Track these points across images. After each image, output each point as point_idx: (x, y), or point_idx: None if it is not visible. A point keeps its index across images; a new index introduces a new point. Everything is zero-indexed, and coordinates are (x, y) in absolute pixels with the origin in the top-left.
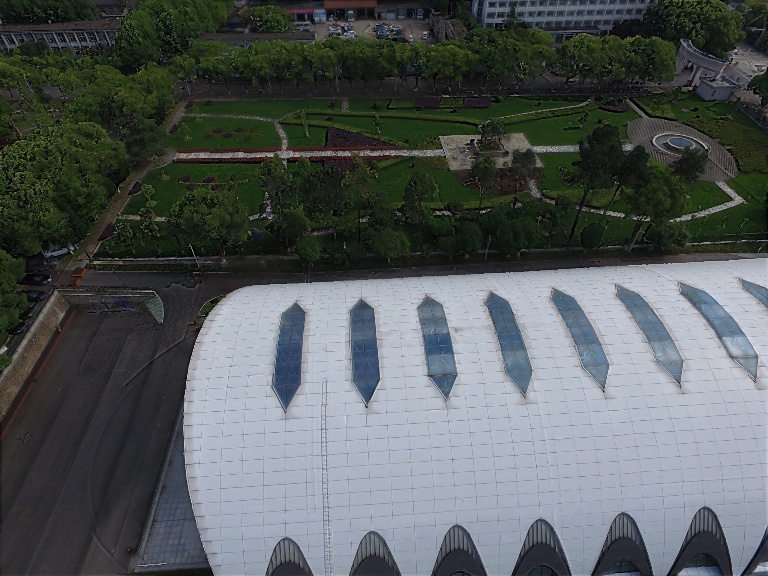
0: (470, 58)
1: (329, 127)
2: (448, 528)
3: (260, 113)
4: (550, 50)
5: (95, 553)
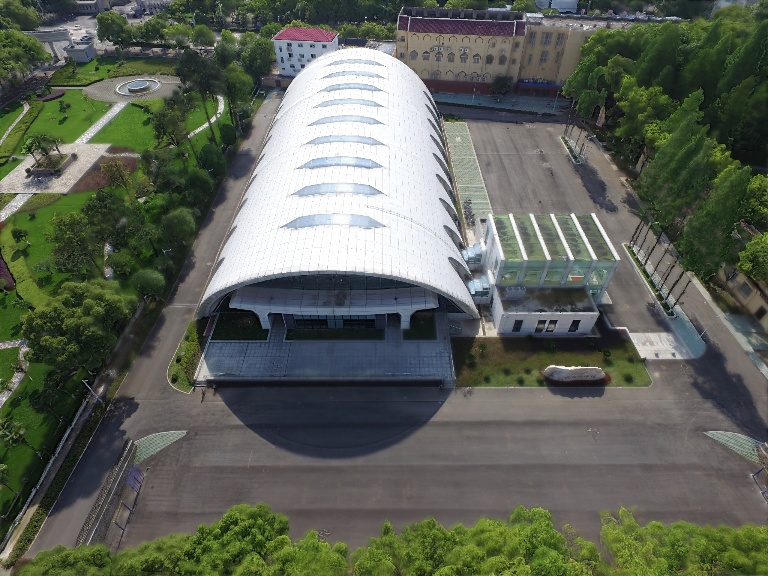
0: None
1: None
2: (440, 202)
3: None
4: None
5: (442, 415)
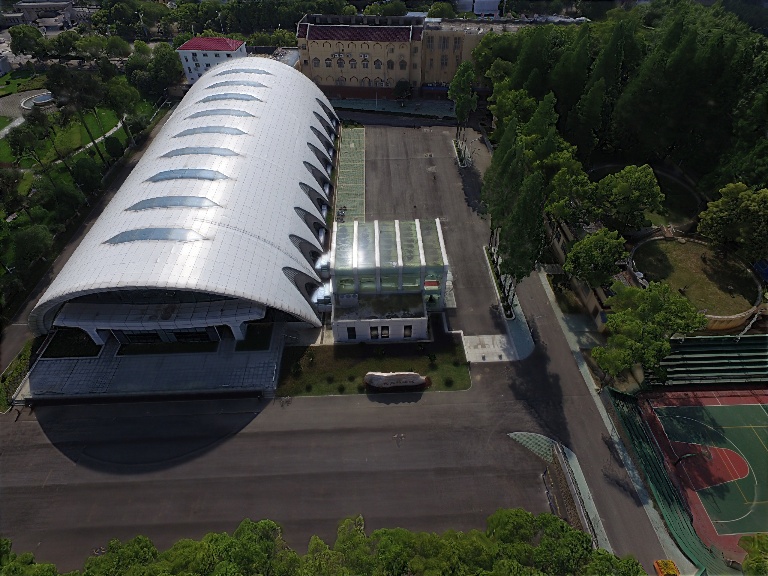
0: None
1: None
2: (295, 211)
3: None
4: None
5: (254, 426)
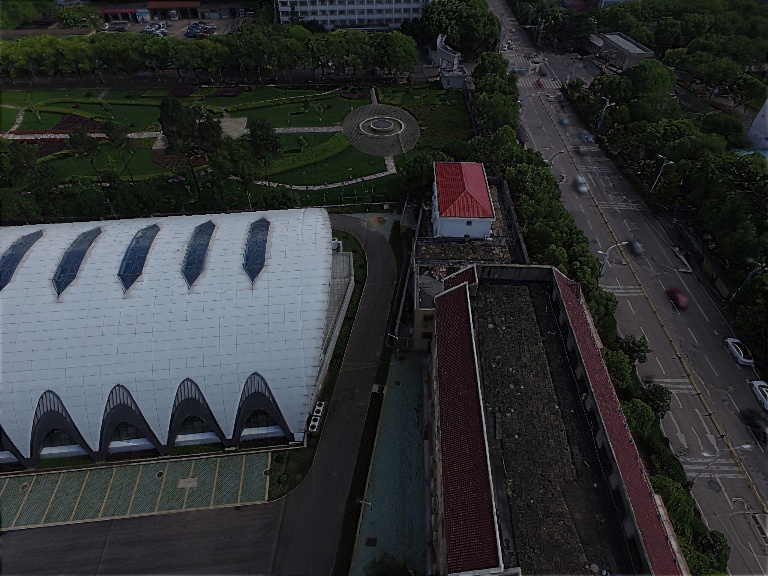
0: (219, 51)
1: (68, 113)
2: None
3: (13, 102)
4: (296, 43)
5: None
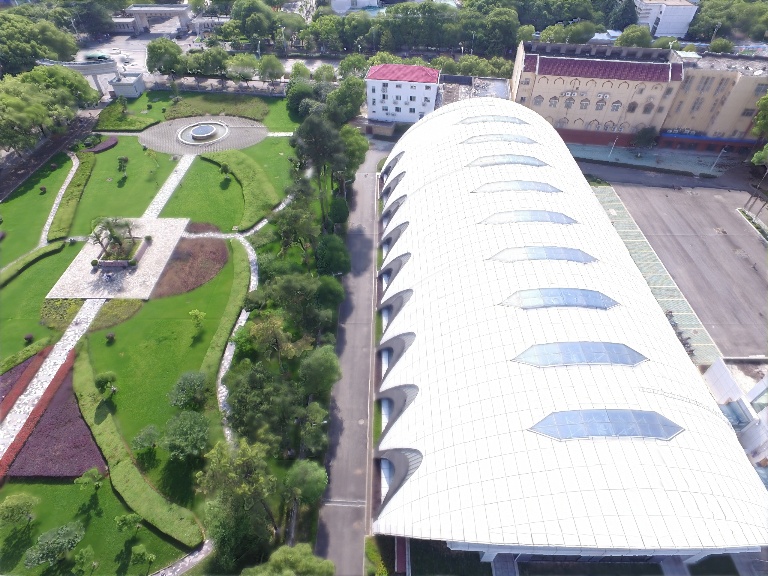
0: None
1: None
2: None
3: None
4: None
5: None
